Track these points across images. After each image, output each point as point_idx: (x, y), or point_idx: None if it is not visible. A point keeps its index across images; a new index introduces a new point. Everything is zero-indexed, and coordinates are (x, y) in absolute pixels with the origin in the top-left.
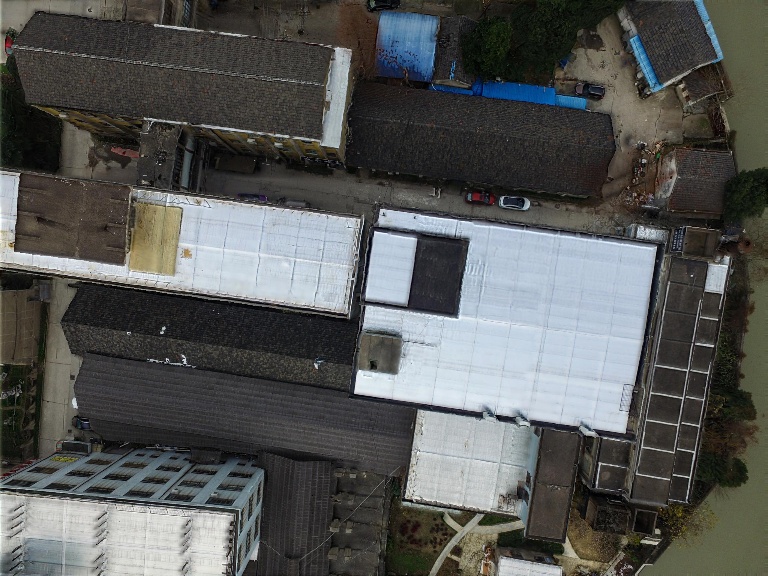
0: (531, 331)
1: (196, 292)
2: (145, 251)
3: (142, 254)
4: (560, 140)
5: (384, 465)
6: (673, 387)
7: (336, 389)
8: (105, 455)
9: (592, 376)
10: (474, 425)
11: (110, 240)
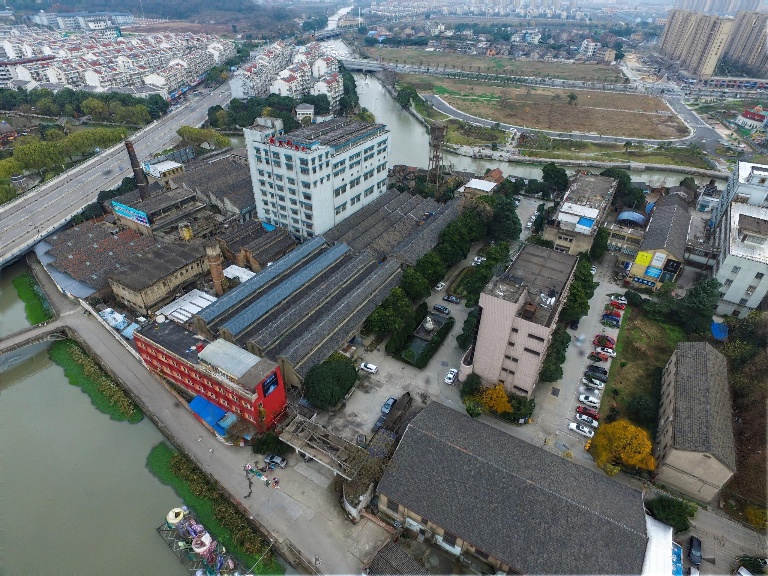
0: None
1: None
2: None
3: None
4: None
5: None
6: None
7: None
8: None
9: None
10: None
11: (762, 223)
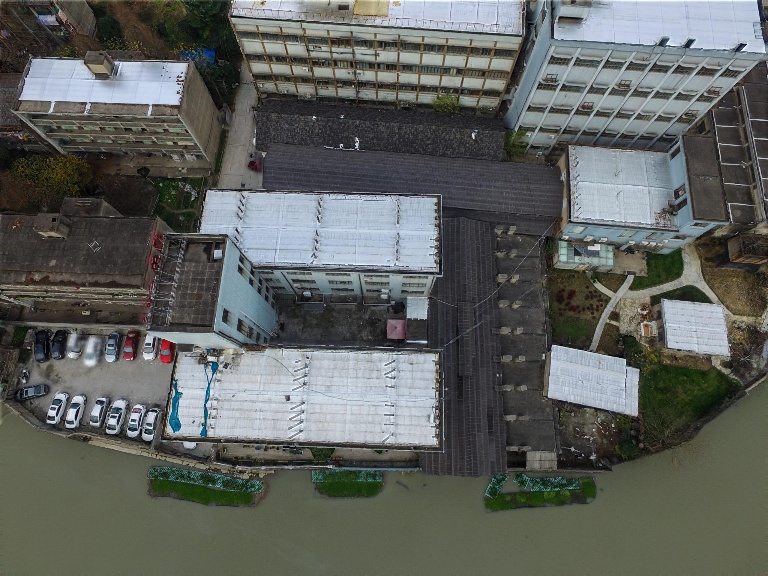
0: None
1: (404, 26)
2: (366, 2)
3: (363, 4)
4: None
5: (537, 225)
6: None
7: (489, 160)
8: None
9: (728, 19)
10: (619, 160)
11: None
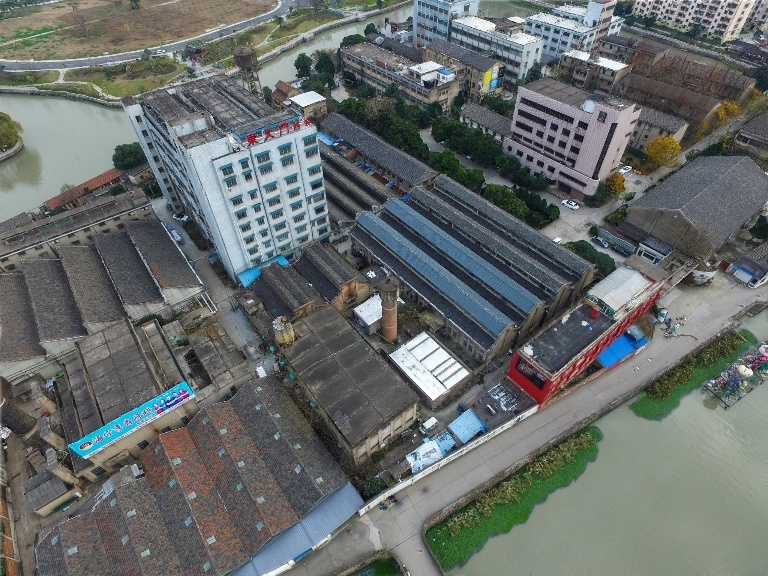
0: None
1: None
2: None
3: None
4: (395, 41)
5: None
6: None
7: None
8: None
9: None
10: None
11: None
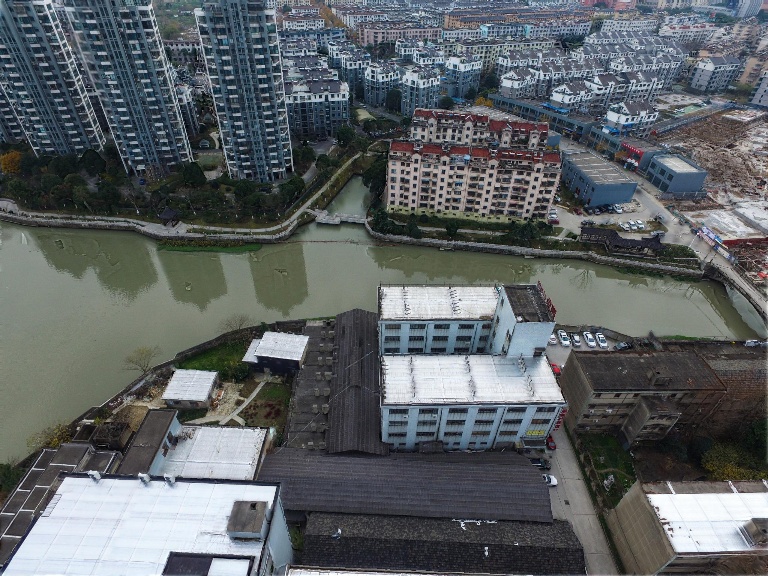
0: (113, 557)
1: None
2: None
3: None
4: None
5: None
6: (7, 546)
7: (324, 513)
8: (509, 440)
9: (73, 521)
10: None
11: None
